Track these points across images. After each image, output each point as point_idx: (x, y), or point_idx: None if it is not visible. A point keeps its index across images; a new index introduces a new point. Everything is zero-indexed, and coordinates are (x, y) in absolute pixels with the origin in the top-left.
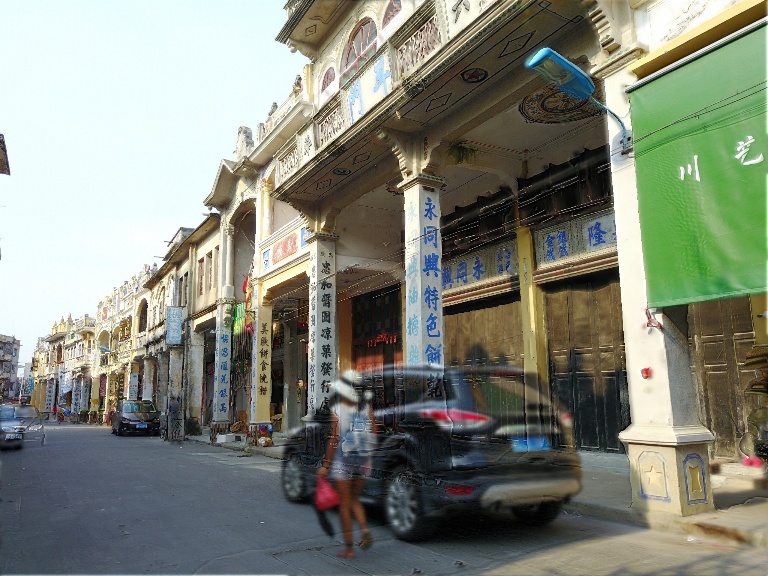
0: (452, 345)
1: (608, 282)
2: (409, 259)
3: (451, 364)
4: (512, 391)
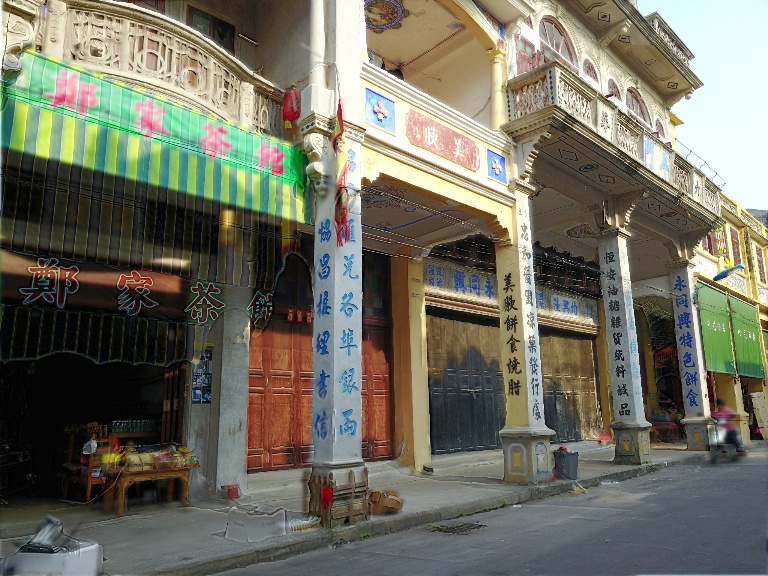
0: (449, 351)
1: (549, 335)
2: (626, 293)
3: (449, 371)
4: (502, 402)
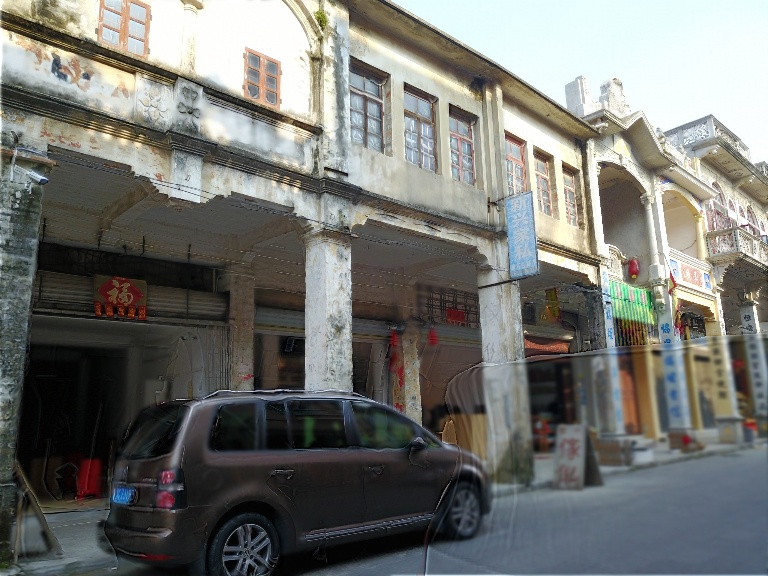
0: None
1: None
2: None
3: None
4: None
